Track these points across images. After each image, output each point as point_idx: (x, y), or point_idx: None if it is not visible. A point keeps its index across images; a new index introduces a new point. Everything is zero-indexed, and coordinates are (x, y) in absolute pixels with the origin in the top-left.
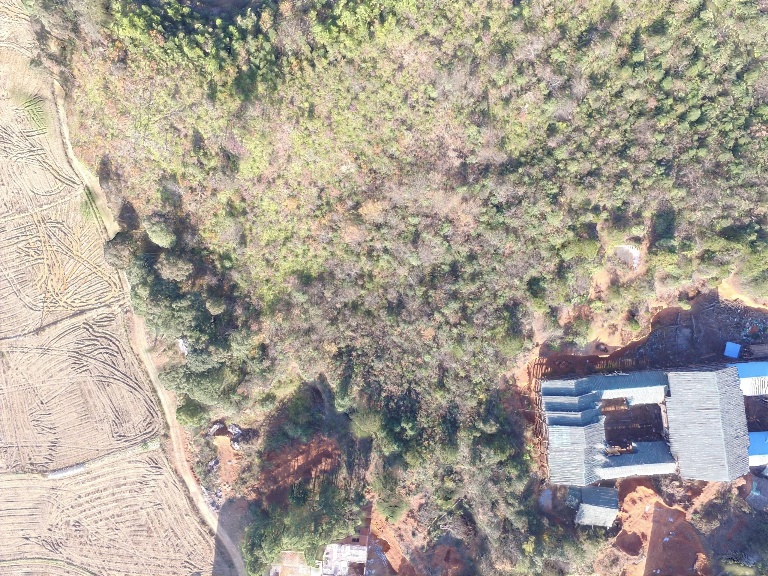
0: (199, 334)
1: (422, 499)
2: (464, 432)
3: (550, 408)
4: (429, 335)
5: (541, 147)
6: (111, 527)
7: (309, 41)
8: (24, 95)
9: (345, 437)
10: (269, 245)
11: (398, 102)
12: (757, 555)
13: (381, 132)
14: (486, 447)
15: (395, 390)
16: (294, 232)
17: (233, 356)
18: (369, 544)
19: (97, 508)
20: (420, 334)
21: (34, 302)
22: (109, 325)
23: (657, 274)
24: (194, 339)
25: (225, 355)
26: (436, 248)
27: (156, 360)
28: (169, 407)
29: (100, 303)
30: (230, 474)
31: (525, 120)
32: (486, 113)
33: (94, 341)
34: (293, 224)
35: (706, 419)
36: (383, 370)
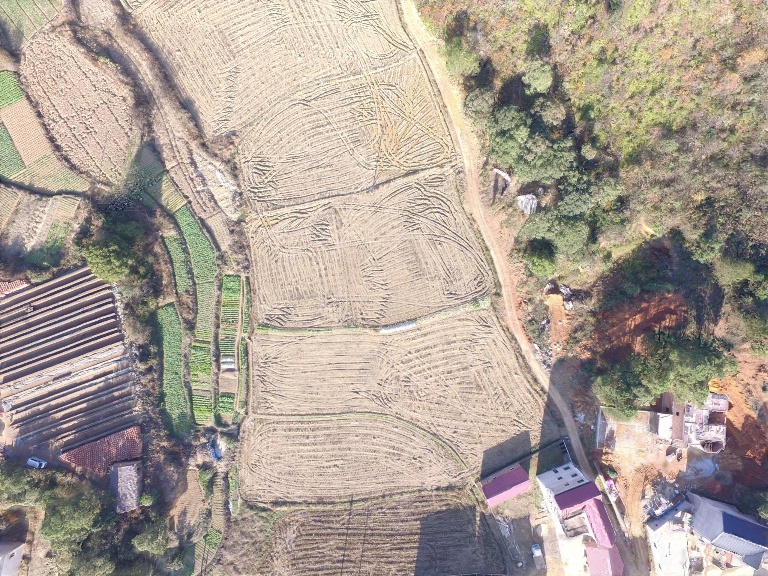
0: (578, 175)
1: None
2: None
3: None
4: None
5: None
6: (440, 383)
7: None
8: None
9: (694, 292)
10: (636, 96)
11: None
12: None
13: None
14: None
15: (764, 239)
16: (663, 83)
17: (597, 204)
18: None
19: (427, 364)
20: None
21: (367, 161)
22: (441, 185)
23: None
24: (576, 179)
25: (596, 200)
26: None
27: (490, 219)
28: (501, 266)
29: (432, 164)
30: (560, 334)
31: None
32: None
33: (426, 200)
34: (663, 75)
35: None
36: (749, 220)
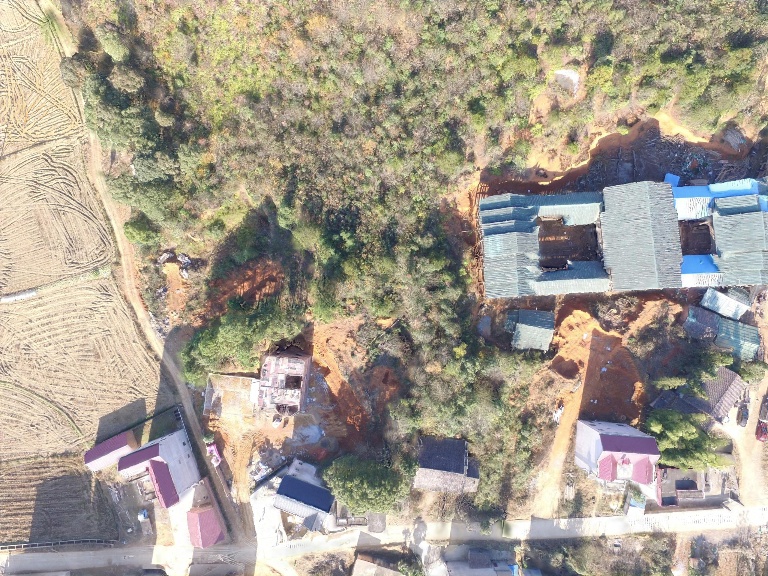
0: (147, 141)
1: (362, 320)
2: (402, 246)
3: (486, 222)
4: (370, 148)
5: None
6: (60, 351)
7: None
8: None
9: (289, 259)
10: (219, 64)
11: None
12: (690, 374)
13: None
14: (422, 257)
15: (336, 204)
16: (244, 51)
17: (181, 171)
18: (311, 372)
19: (47, 332)
20: (361, 148)
21: None
22: (67, 156)
23: (595, 98)
24: (141, 145)
25: (172, 166)
26: (380, 67)
27: None
28: (121, 235)
29: (59, 135)
30: (178, 302)
31: None
32: None
33: (52, 171)
34: (243, 43)
35: (638, 229)
36: (325, 186)
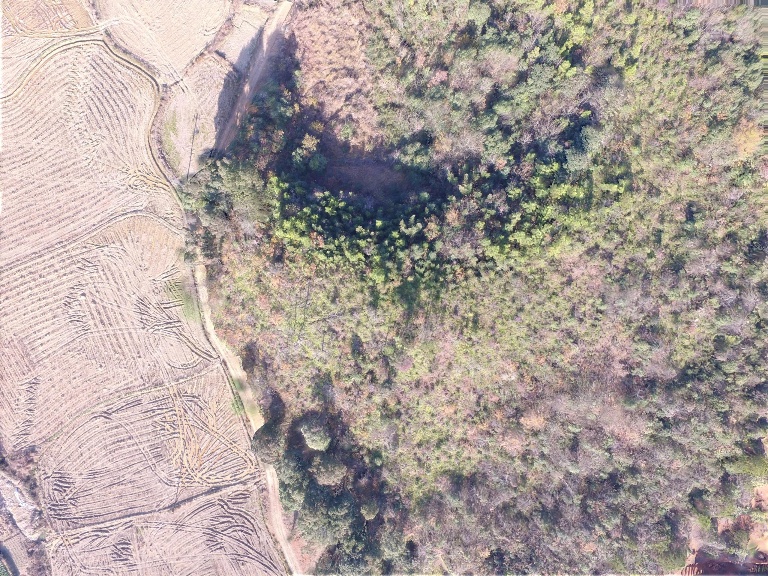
0: (355, 542)
1: None
2: None
3: None
4: (589, 549)
5: (708, 359)
6: None
7: (478, 254)
8: (161, 266)
9: None
10: (422, 446)
11: (564, 313)
12: None
13: (545, 341)
14: None
15: None
16: (449, 434)
17: None
18: None
19: None
20: (579, 546)
21: (169, 477)
22: (244, 502)
23: None
24: (351, 549)
25: None
26: (596, 457)
27: (292, 541)
28: None
29: (236, 480)
30: None
31: (693, 332)
32: (655, 328)
33: (229, 518)
34: (449, 427)
35: None
36: None
